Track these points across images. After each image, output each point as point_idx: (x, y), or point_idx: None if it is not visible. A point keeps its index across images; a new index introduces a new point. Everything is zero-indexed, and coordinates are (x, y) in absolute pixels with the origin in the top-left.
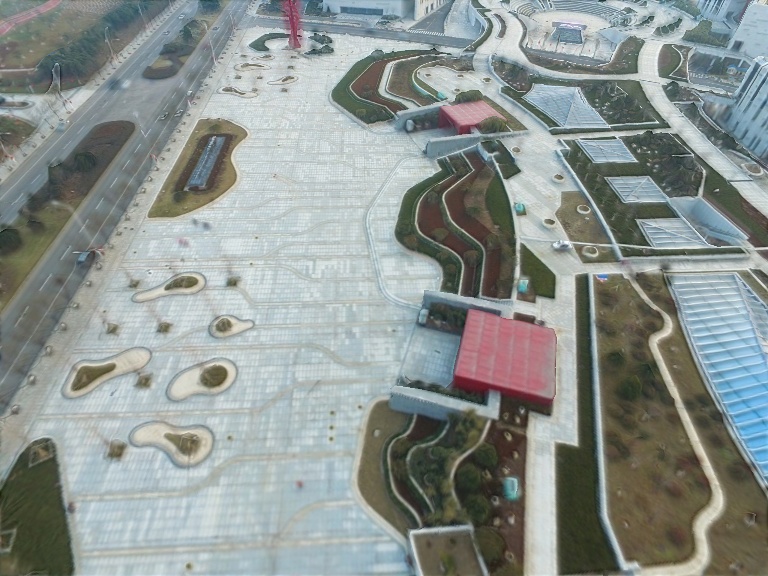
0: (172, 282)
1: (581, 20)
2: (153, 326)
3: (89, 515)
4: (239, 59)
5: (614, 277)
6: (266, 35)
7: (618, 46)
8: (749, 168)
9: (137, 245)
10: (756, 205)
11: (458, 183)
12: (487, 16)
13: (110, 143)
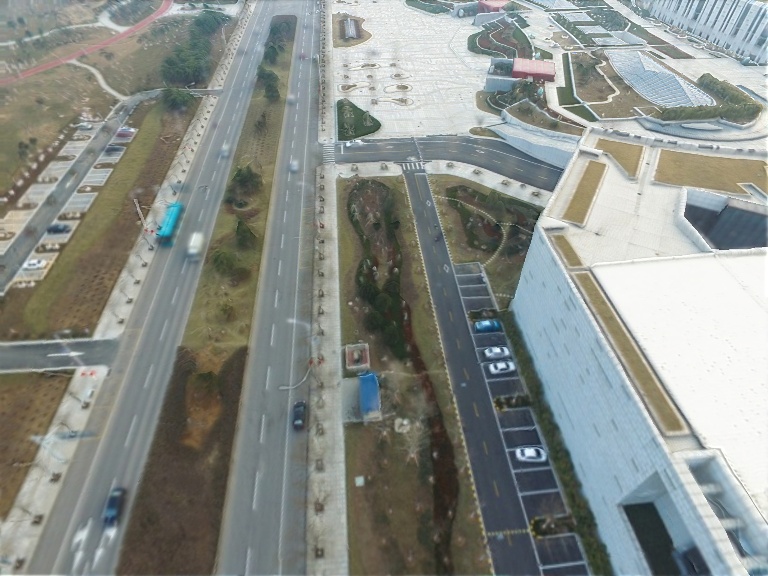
0: (364, 65)
1: None
2: (364, 77)
3: (375, 114)
4: None
5: None
6: None
7: None
8: (655, 22)
9: (336, 56)
10: (655, 34)
11: (497, 31)
12: None
13: (289, 23)
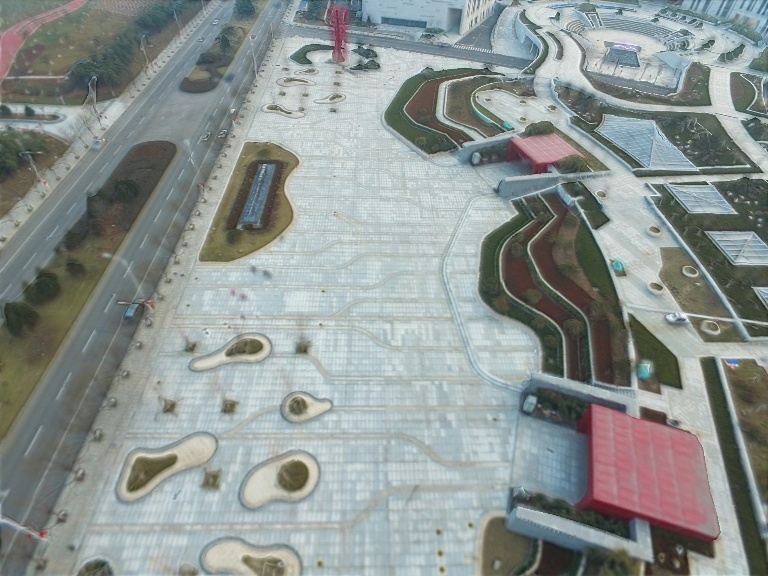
0: (234, 346)
1: (634, 40)
2: (216, 404)
3: None
4: (281, 73)
5: (746, 363)
6: (307, 46)
7: (684, 73)
8: None
9: (190, 296)
10: None
11: (542, 232)
12: (539, 34)
13: (151, 167)
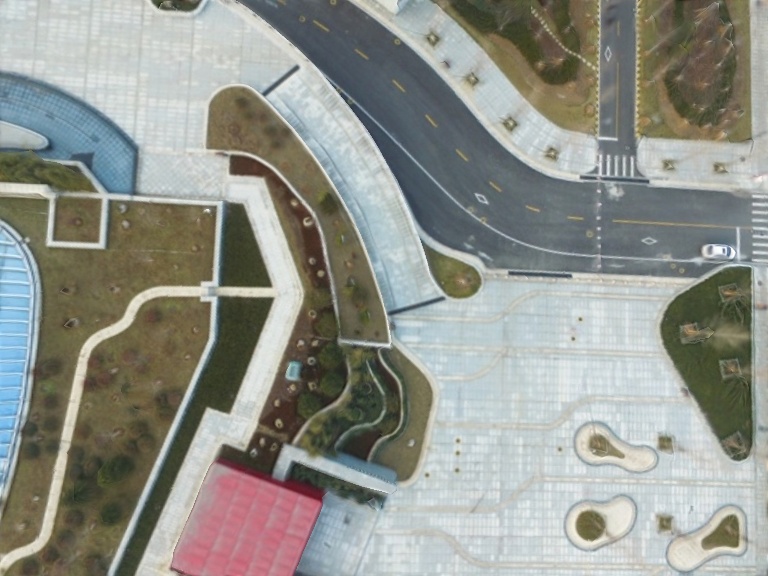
0: None
1: None
2: None
3: (667, 385)
4: None
5: None
6: None
7: None
8: None
9: None
10: None
11: None
12: None
13: None
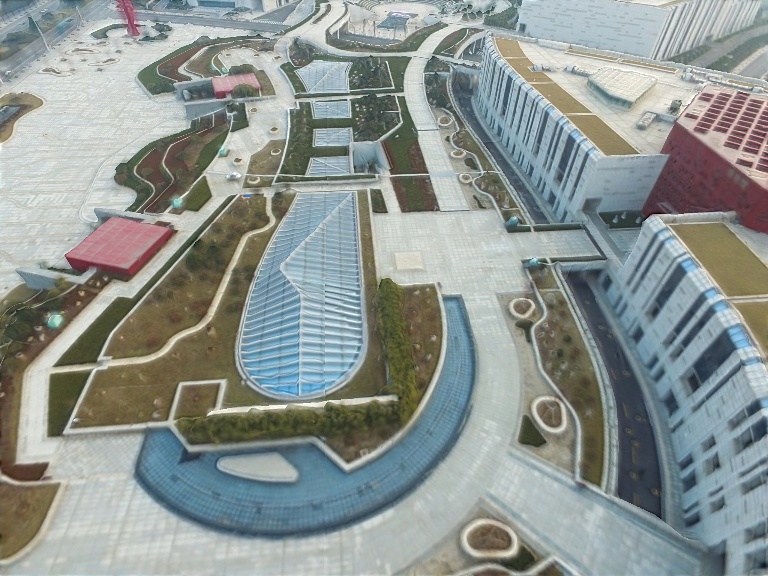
0: None
1: (418, 10)
2: None
3: None
4: (74, 45)
5: (256, 196)
6: (112, 25)
7: (417, 30)
8: (442, 120)
9: None
10: (423, 147)
11: None
12: (320, 6)
13: None
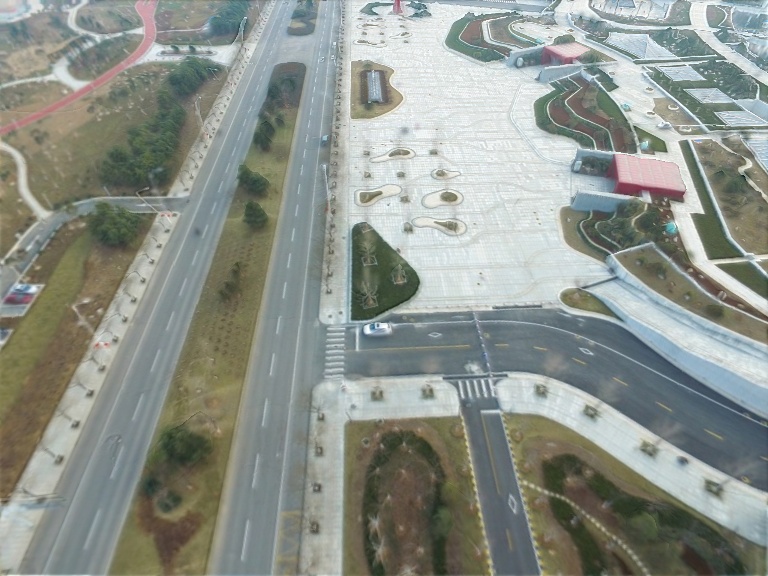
0: (393, 152)
1: None
2: (393, 174)
3: (409, 254)
4: (358, 21)
5: (706, 141)
6: (370, 4)
7: (671, 6)
8: None
9: (354, 134)
10: None
11: (573, 95)
12: None
13: (295, 76)
